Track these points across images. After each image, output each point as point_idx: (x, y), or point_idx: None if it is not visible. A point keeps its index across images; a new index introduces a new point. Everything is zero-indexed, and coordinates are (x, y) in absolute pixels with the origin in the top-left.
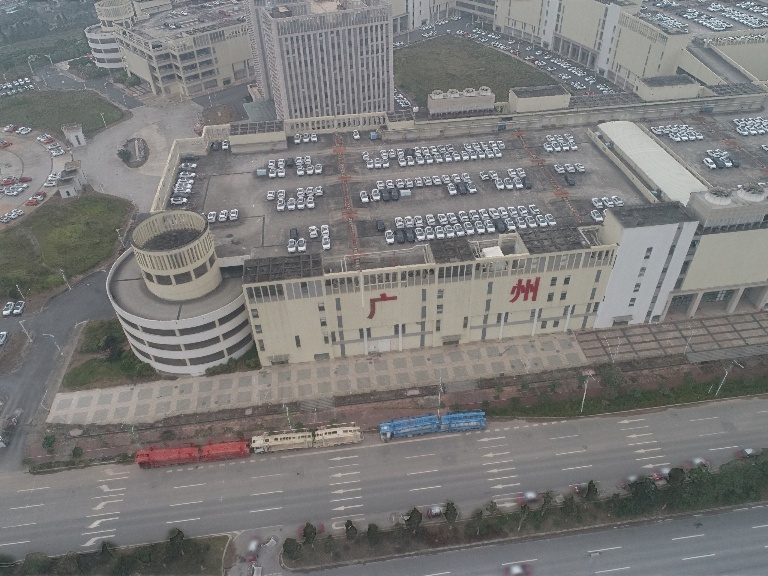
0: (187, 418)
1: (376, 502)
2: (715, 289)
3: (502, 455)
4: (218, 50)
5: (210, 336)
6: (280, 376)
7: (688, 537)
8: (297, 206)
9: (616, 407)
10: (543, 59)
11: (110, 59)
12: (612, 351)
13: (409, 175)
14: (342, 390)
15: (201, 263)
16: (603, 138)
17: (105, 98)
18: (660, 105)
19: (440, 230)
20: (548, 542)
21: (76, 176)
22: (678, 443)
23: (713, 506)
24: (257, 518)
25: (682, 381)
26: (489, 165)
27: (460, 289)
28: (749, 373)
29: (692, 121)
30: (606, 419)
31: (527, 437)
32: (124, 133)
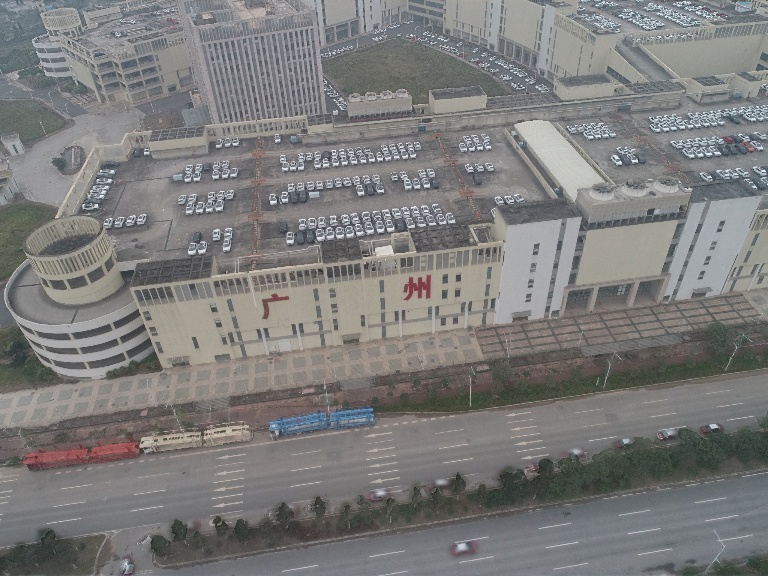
0: (82, 421)
1: (256, 499)
2: (610, 283)
3: (386, 450)
4: (161, 57)
5: (106, 339)
6: (180, 377)
7: (555, 526)
8: (205, 210)
9: (504, 401)
10: (488, 61)
11: (58, 68)
12: None
13: (322, 177)
14: (239, 390)
15: (95, 267)
16: (519, 137)
17: (50, 107)
18: (577, 104)
19: (340, 231)
20: (418, 534)
21: (6, 185)
22: (560, 435)
23: (583, 495)
24: (137, 517)
25: None
26: (402, 166)
27: (352, 288)
28: (640, 365)
29: (609, 119)
30: (494, 413)
31: (414, 432)
32: (63, 141)
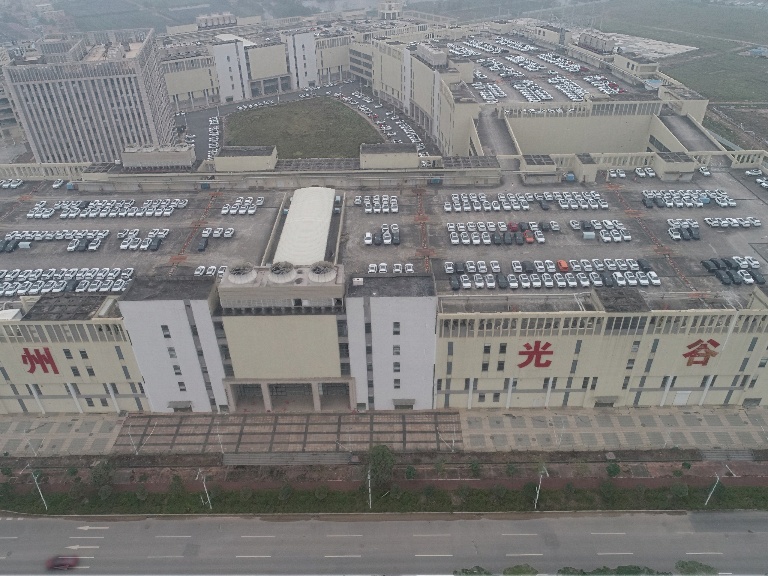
0: None
1: None
2: (279, 381)
3: None
4: None
5: None
6: None
7: None
8: None
9: (87, 509)
10: (394, 124)
11: None
12: (148, 441)
13: (57, 227)
14: None
15: None
16: None
17: None
18: (375, 173)
19: (1, 287)
20: None
21: None
22: (114, 563)
23: None
24: None
25: (193, 486)
26: (147, 223)
27: None
28: (277, 486)
29: (409, 193)
30: (68, 522)
31: None
32: None
